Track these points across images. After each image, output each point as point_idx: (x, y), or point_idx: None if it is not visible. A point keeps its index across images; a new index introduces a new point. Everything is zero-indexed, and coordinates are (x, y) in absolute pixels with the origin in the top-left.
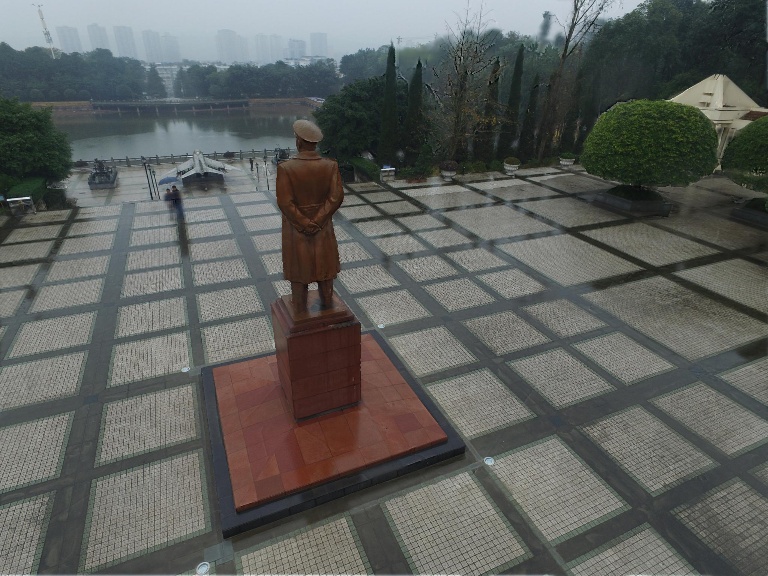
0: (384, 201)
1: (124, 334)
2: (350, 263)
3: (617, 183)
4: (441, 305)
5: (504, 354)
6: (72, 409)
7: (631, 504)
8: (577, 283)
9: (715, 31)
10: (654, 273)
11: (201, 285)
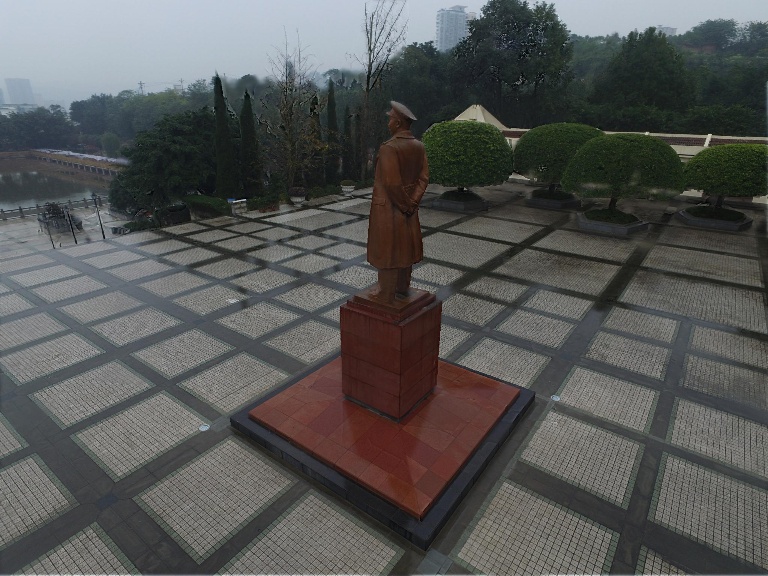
0: (256, 230)
1: (73, 420)
2: (281, 287)
3: (436, 193)
4: None
5: (486, 324)
6: (89, 522)
7: (658, 390)
8: (481, 264)
9: (464, 73)
10: (521, 248)
11: (126, 344)
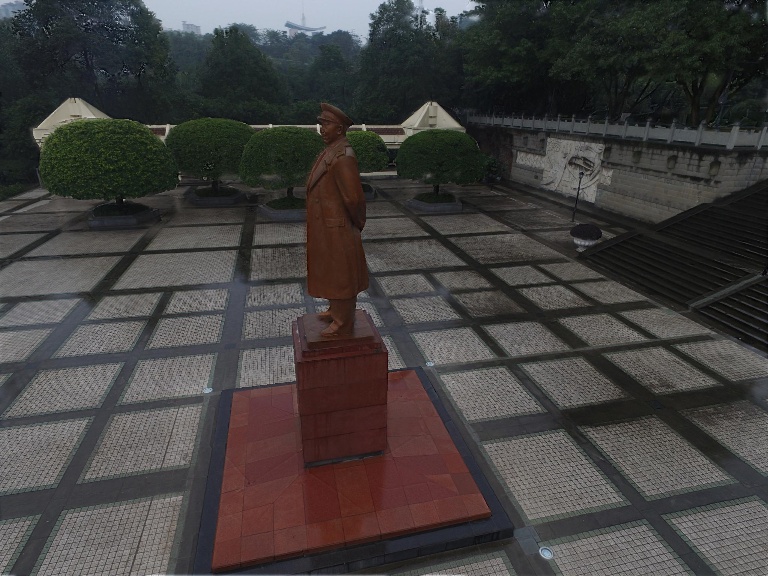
0: None
1: None
2: None
3: (73, 210)
4: (201, 344)
5: None
6: None
7: (468, 326)
8: (231, 276)
9: (38, 57)
10: (247, 249)
11: None
